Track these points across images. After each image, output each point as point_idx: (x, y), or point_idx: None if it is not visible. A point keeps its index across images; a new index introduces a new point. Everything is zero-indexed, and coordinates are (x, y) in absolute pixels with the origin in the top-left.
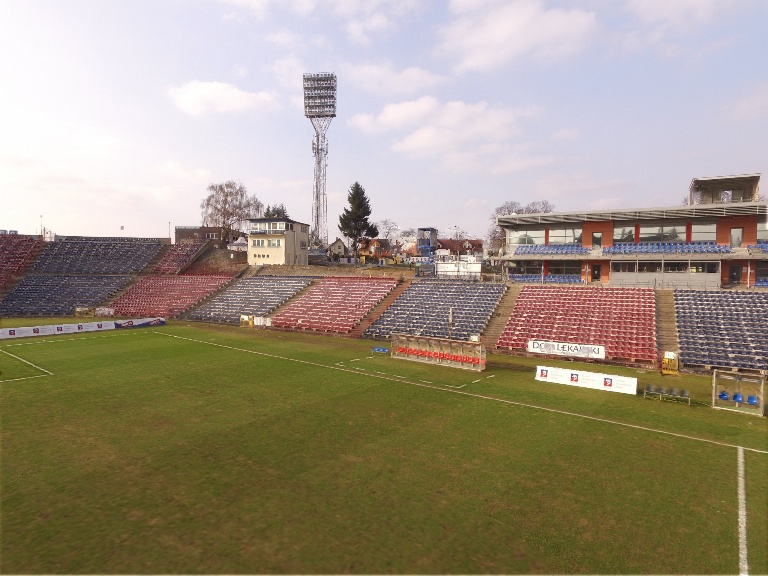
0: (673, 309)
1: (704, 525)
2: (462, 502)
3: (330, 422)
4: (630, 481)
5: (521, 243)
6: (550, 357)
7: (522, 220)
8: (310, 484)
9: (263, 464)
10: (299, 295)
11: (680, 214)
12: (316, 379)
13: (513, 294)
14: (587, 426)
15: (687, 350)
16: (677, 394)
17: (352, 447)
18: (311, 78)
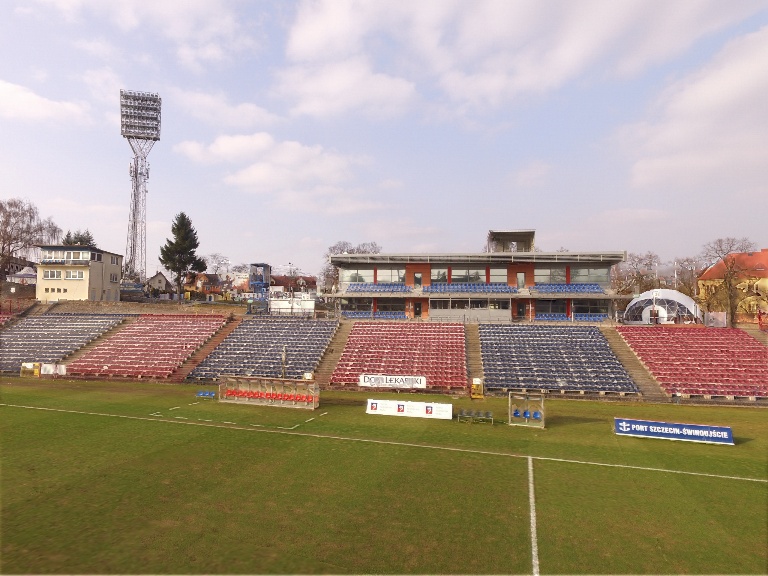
0: (478, 341)
1: (506, 531)
2: (294, 552)
3: (142, 484)
4: (449, 501)
5: (352, 281)
6: (379, 390)
7: (353, 259)
8: (112, 565)
9: (46, 551)
10: (106, 336)
11: (481, 260)
12: (125, 434)
13: (345, 330)
14: (412, 454)
15: (489, 376)
16: (483, 416)
17: (169, 510)
18: (130, 96)
